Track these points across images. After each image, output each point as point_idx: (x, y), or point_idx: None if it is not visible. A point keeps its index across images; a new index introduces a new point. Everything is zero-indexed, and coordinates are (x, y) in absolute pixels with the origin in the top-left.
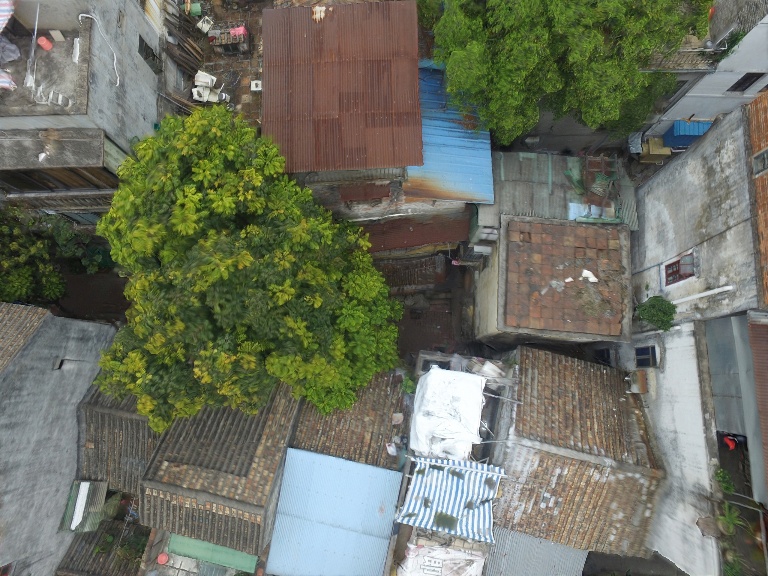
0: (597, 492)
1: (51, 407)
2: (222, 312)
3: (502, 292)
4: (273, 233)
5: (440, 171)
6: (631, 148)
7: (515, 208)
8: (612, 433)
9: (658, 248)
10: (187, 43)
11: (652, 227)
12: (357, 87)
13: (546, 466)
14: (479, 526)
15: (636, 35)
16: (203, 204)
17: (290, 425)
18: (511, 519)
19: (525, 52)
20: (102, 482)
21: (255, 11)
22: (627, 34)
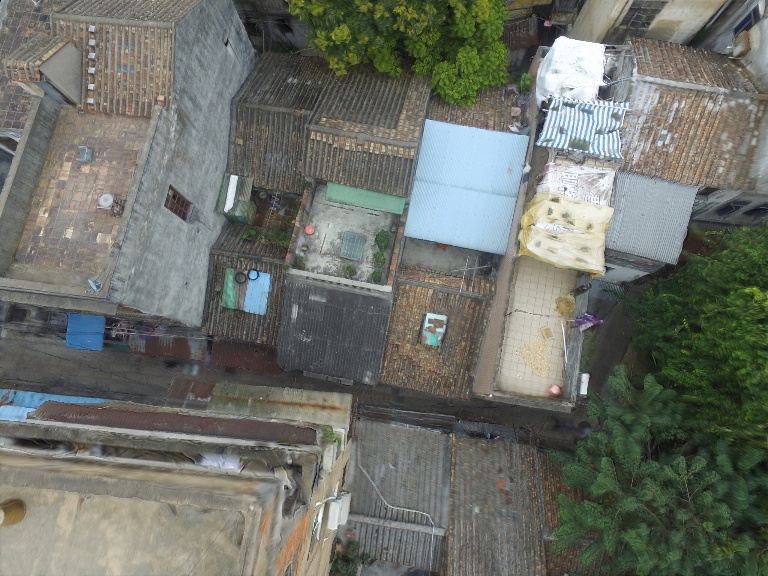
0: (710, 123)
1: (219, 79)
2: None
3: None
4: None
5: None
6: None
7: None
8: (721, 79)
9: None
10: None
11: None
12: None
13: (665, 101)
14: (609, 147)
15: None
16: None
17: (425, 105)
18: (630, 160)
19: None
20: (248, 178)
21: None
22: None
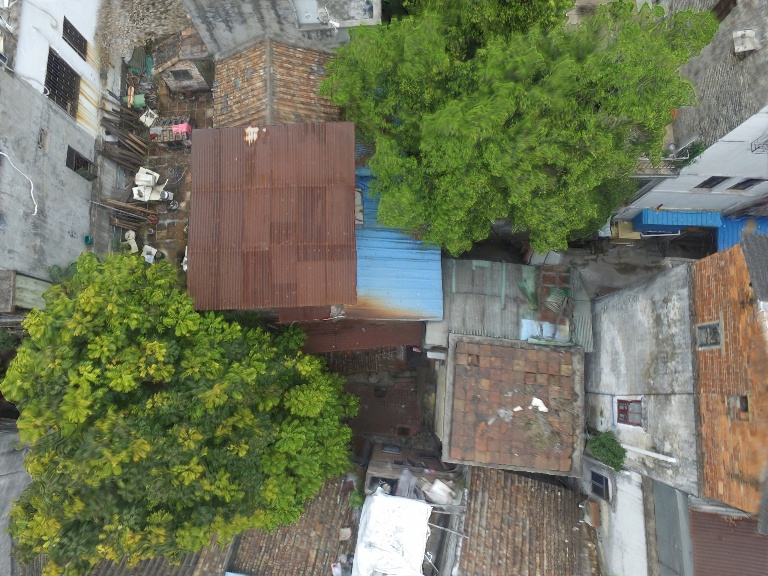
0: None
1: None
2: (127, 486)
3: (448, 420)
4: (183, 399)
5: (385, 288)
6: (599, 232)
7: (465, 325)
8: (562, 571)
9: (612, 376)
10: (128, 139)
11: (607, 350)
12: (289, 216)
13: None
14: None
15: (581, 172)
16: (102, 380)
17: (230, 546)
18: None
19: (461, 194)
20: None
21: (203, 101)
22: (571, 172)
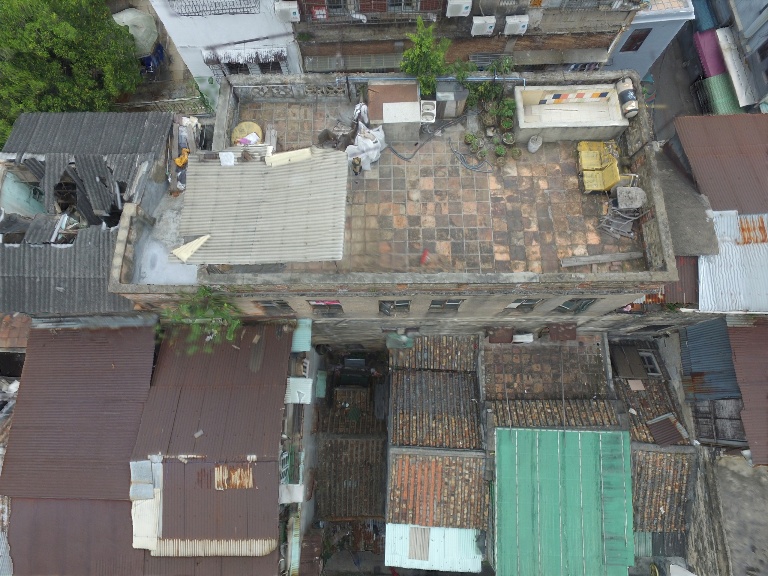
0: None
1: None
2: None
3: None
4: None
5: None
6: None
7: None
8: None
9: None
10: None
11: None
12: None
13: None
14: None
15: (19, 97)
16: None
17: None
18: (0, 522)
19: None
20: None
21: None
22: None
